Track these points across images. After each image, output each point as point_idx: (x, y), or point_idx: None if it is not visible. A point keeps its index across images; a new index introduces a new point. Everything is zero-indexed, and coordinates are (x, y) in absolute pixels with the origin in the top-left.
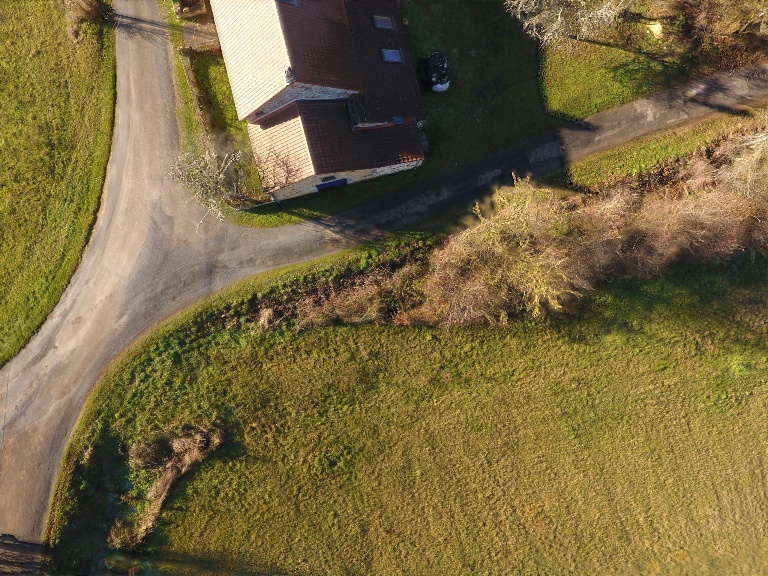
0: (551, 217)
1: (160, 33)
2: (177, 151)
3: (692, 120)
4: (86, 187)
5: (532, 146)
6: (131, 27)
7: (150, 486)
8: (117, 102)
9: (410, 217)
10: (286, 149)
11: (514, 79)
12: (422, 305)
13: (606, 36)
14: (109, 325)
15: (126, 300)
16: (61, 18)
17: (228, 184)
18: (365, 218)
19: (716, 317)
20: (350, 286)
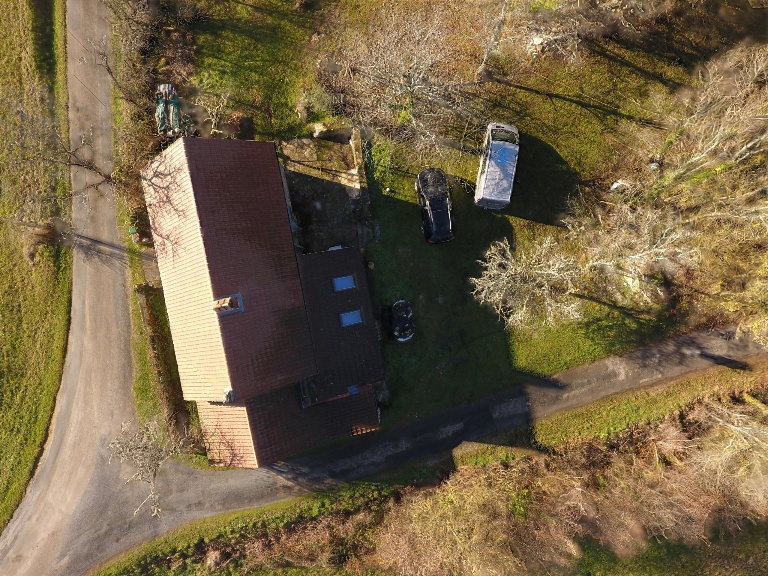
0: (501, 540)
1: (119, 257)
2: (129, 384)
3: (666, 380)
4: (34, 417)
5: (497, 401)
6: (90, 249)
7: None
8: (71, 328)
9: (366, 467)
10: (231, 432)
11: (481, 331)
12: (376, 551)
13: (581, 286)
14: (50, 566)
15: (68, 540)
16: (18, 238)
17: (179, 427)
18: (319, 466)
19: (684, 570)
20: (301, 530)
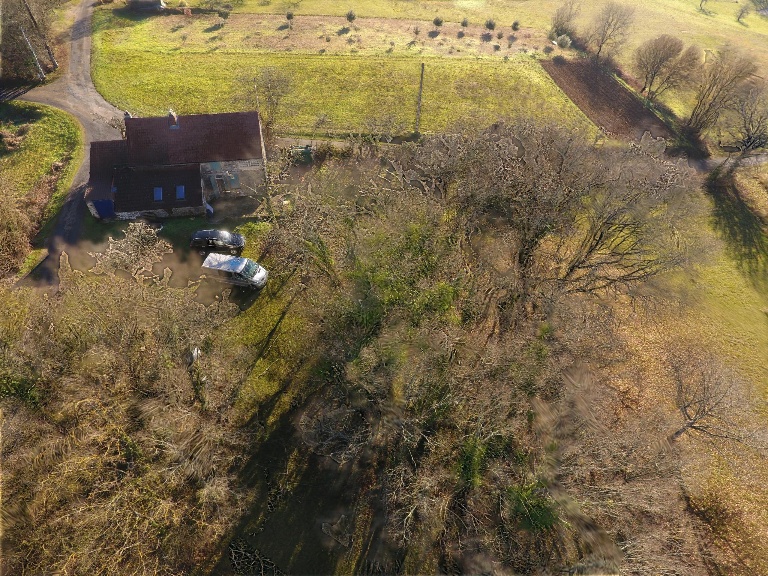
0: None
1: None
2: None
3: None
4: None
5: None
6: None
7: (10, 131)
8: None
9: None
10: None
11: None
12: None
13: None
14: None
15: (104, 124)
16: None
17: None
18: None
19: None
20: None
